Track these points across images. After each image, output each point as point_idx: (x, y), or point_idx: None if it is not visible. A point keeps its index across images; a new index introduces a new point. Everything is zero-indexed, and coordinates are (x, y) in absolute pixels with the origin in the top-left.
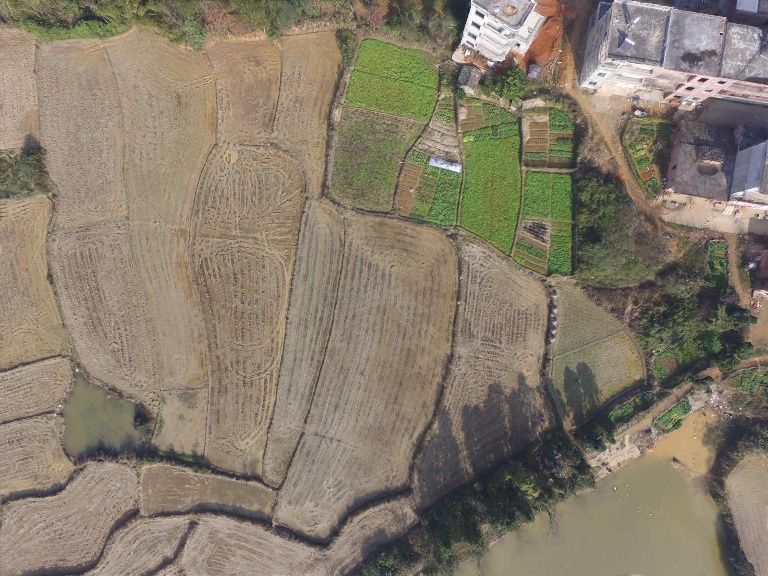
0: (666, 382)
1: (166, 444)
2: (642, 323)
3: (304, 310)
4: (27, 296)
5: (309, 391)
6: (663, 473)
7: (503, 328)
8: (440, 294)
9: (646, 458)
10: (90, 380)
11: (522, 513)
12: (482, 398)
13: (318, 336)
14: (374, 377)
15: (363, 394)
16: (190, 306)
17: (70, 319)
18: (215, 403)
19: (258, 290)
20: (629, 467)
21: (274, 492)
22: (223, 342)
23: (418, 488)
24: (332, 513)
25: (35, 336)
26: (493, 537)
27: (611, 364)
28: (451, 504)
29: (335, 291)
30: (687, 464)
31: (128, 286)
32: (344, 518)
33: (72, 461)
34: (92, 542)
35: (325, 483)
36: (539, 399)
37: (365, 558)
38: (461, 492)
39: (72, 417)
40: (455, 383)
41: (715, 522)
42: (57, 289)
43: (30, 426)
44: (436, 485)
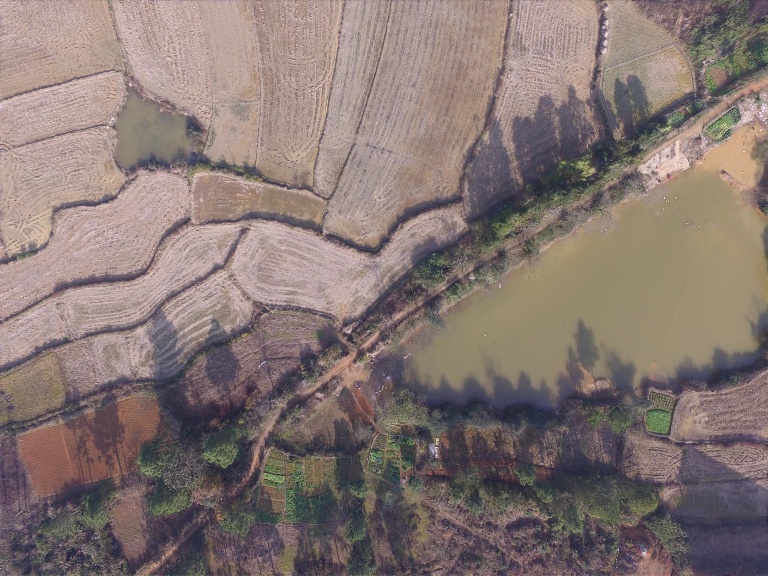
0: (716, 92)
1: (218, 156)
2: (693, 33)
3: (357, 24)
4: (82, 12)
5: (361, 103)
6: (712, 186)
7: (554, 42)
8: (492, 10)
9: (695, 170)
10: (143, 94)
11: (578, 187)
12: (533, 110)
13: (370, 50)
14: (426, 90)
15: (414, 106)
16: (244, 20)
17: (124, 33)
18: (267, 115)
19: (311, 5)
20: (678, 179)
21: (325, 202)
22: (276, 55)
23: (468, 198)
24: (382, 223)
25: (89, 51)
26: (544, 238)
27: (661, 77)
28: (502, 207)
29: (388, 6)
30: (736, 177)
31: (183, 1)
32: (394, 227)
33: (124, 173)
34: (142, 251)
35: (376, 193)
36: (589, 112)
37: (415, 265)
38: (511, 199)
39: (124, 131)
40: (506, 95)
41: (763, 235)
42: (112, 3)
43: (82, 139)
44: (486, 195)
